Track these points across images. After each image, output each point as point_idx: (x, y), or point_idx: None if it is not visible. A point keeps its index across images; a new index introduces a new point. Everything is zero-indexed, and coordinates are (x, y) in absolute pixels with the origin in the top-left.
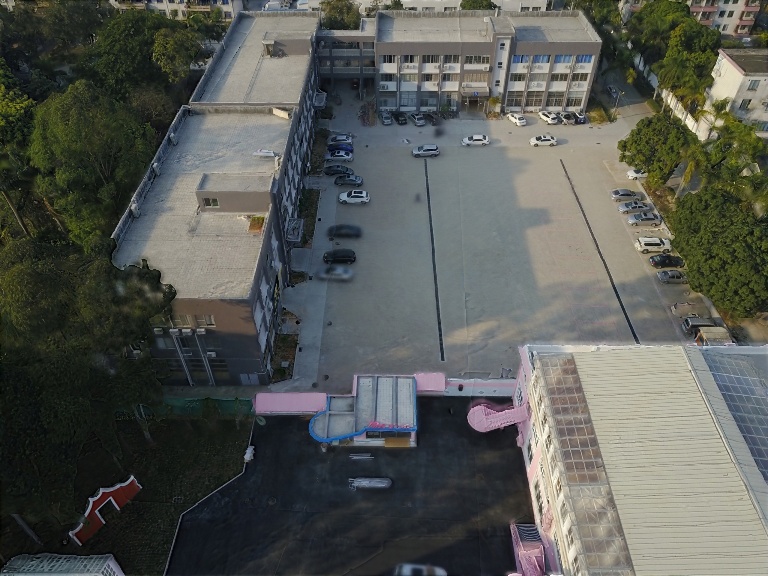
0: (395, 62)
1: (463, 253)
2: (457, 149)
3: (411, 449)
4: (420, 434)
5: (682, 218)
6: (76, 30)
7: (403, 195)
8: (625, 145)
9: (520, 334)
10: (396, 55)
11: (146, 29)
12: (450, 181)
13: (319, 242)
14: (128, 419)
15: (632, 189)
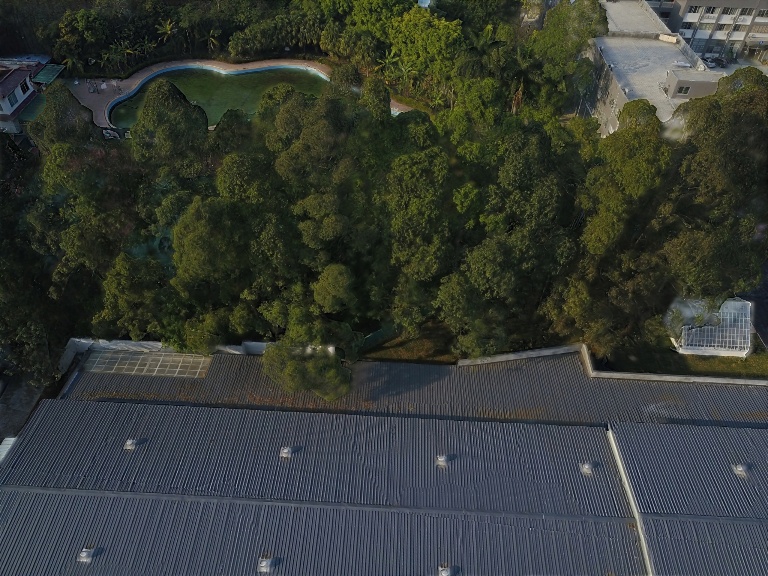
0: (699, 12)
1: None
2: None
3: None
4: None
5: None
6: None
7: None
8: None
9: None
10: (702, 6)
11: None
12: None
13: None
14: None
15: None
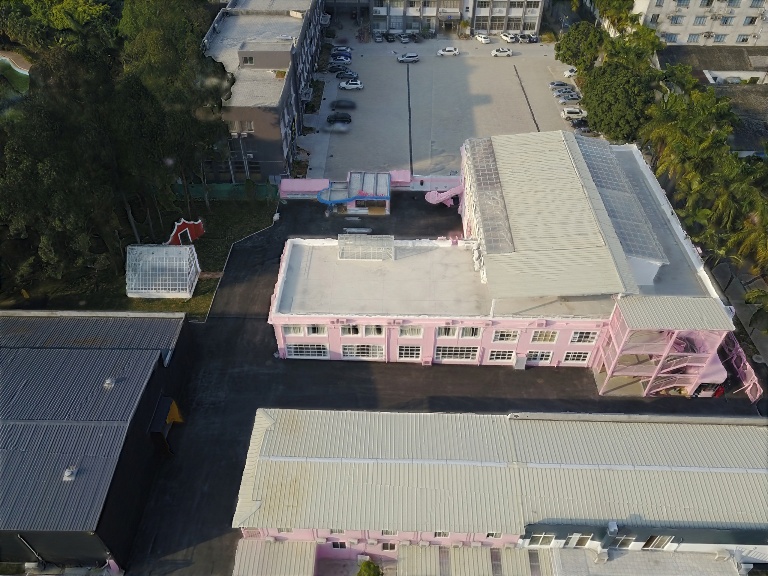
0: None
1: (432, 119)
2: (433, 58)
3: (386, 216)
4: (393, 209)
5: (588, 83)
6: None
7: (389, 86)
8: (559, 46)
9: None
10: None
11: None
12: (426, 78)
13: (324, 112)
14: None
15: (566, 82)
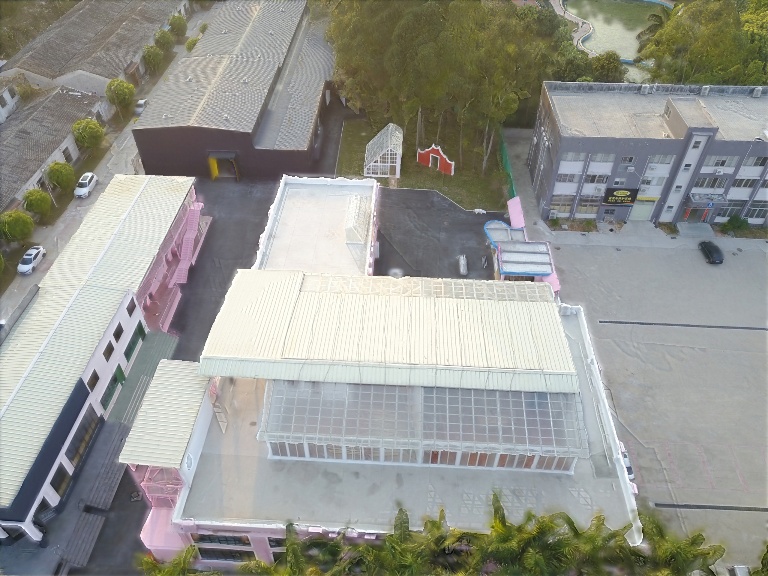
0: None
1: None
2: None
3: None
4: None
5: None
6: None
7: None
8: None
9: (656, 385)
10: None
11: None
12: None
13: (730, 242)
14: (499, 164)
15: None
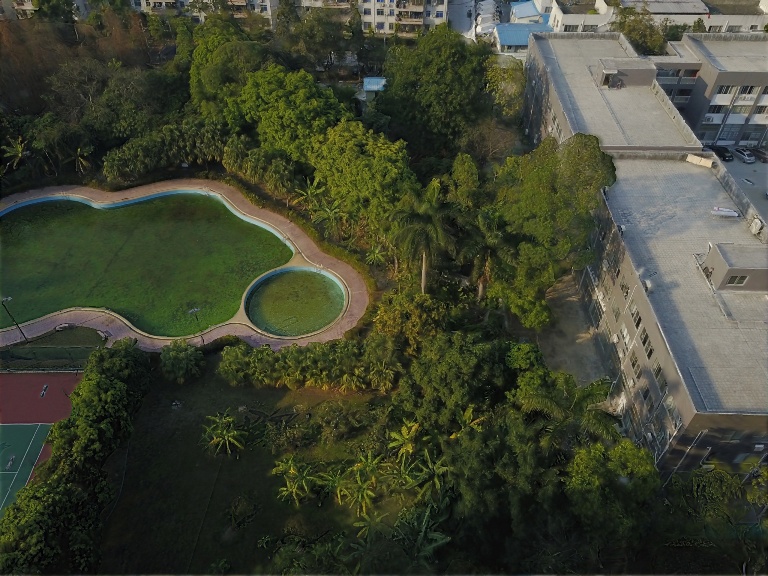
0: (731, 93)
1: None
2: None
3: None
4: None
5: None
6: (324, 48)
7: None
8: None
9: None
10: (736, 85)
11: (474, 56)
12: None
13: None
14: (691, 545)
15: None
